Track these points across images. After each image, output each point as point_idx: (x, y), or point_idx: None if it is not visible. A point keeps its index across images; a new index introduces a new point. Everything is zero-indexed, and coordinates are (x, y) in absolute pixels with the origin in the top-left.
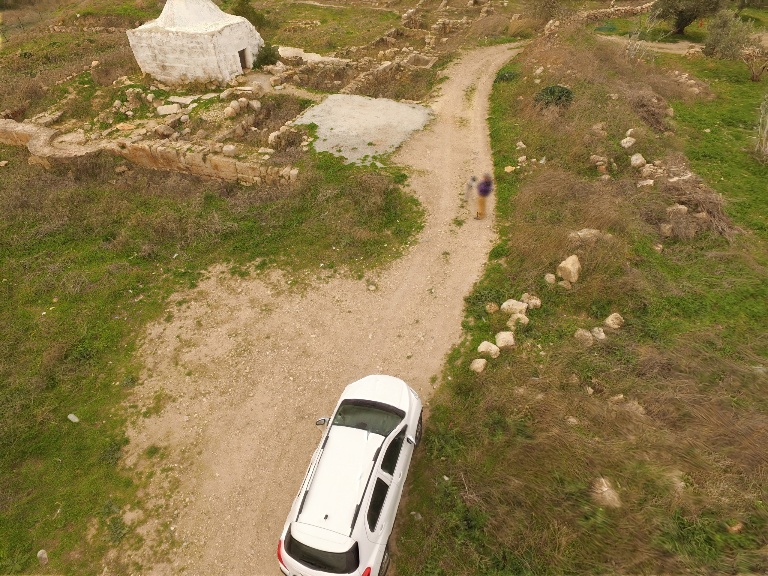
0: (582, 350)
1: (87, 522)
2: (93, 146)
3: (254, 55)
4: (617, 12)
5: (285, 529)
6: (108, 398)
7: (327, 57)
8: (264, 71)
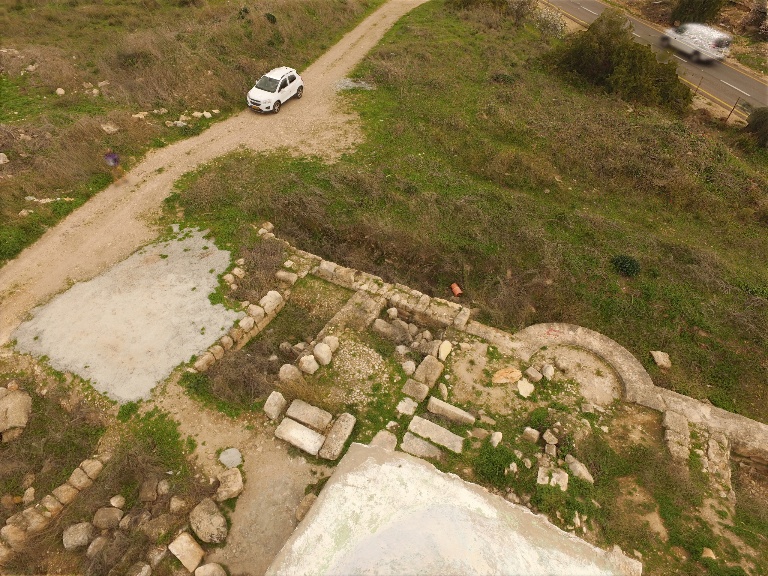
0: (173, 102)
1: None
2: (533, 344)
3: None
4: None
5: (299, 79)
6: None
7: None
8: None
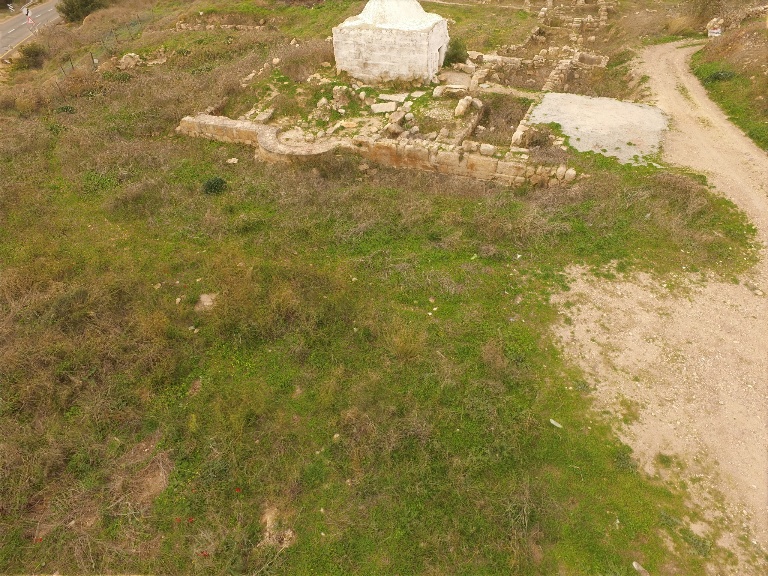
0: None
1: (657, 533)
2: (326, 144)
3: (445, 53)
4: (766, 10)
5: None
6: (574, 403)
7: (492, 55)
8: (455, 69)
